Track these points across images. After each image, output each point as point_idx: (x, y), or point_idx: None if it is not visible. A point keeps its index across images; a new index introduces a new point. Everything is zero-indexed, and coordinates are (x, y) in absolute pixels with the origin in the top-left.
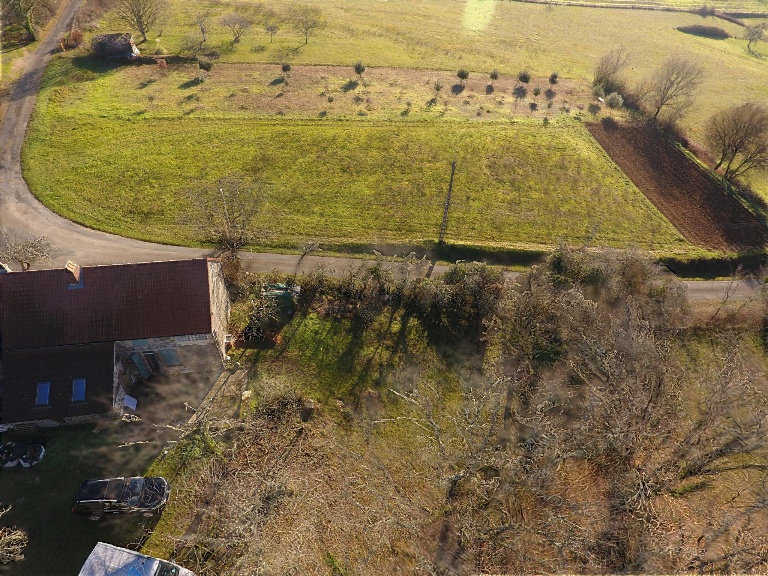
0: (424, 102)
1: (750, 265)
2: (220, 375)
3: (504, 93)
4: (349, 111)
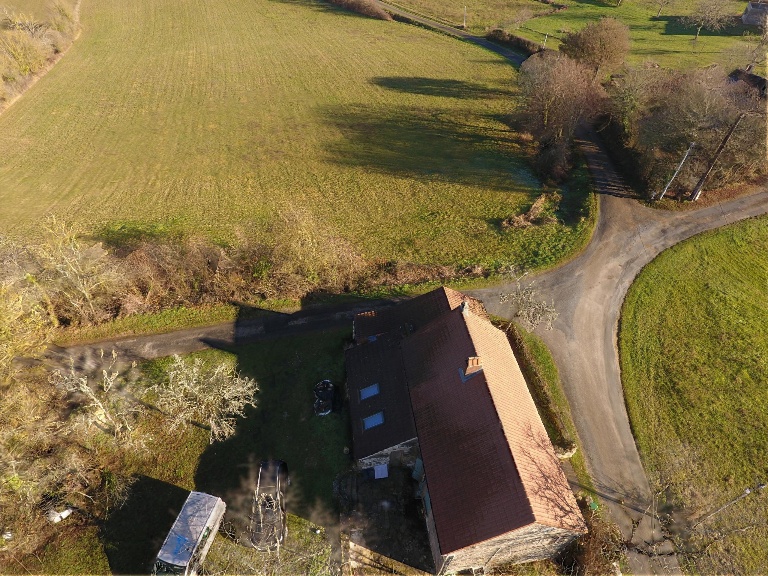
0: None
1: None
2: (427, 572)
3: None
4: None
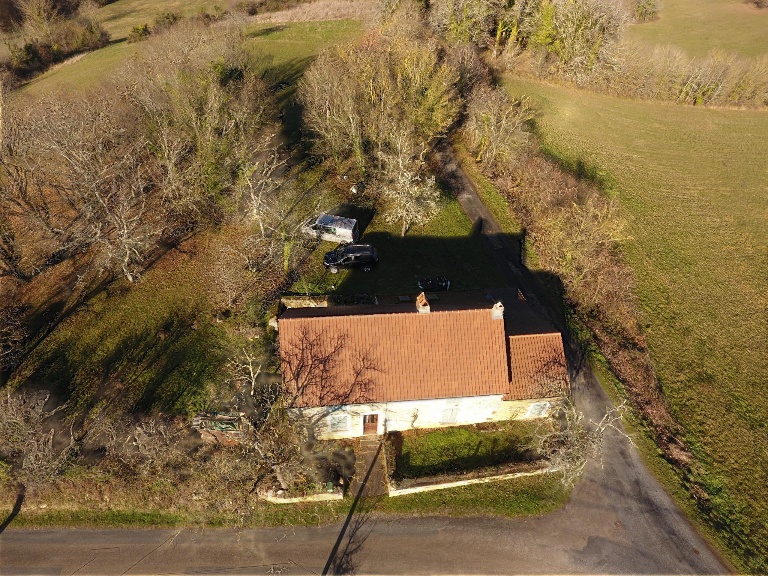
0: None
1: None
2: None
3: None
4: None
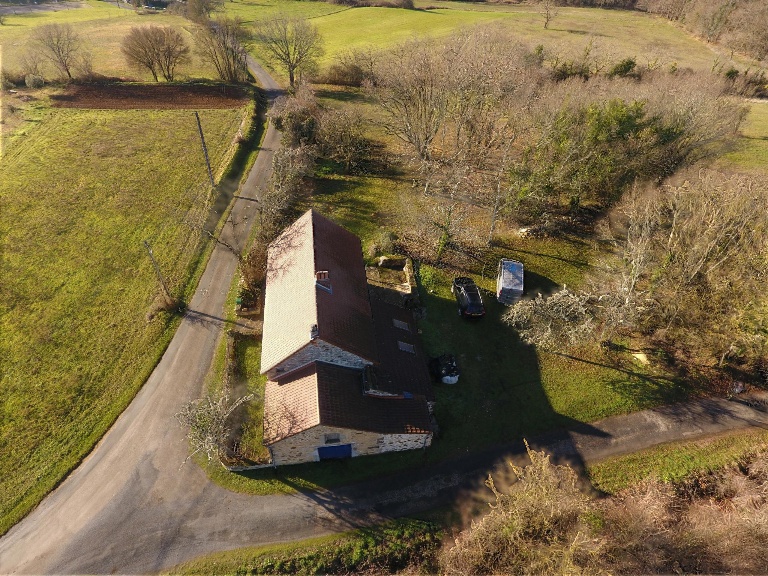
0: None
1: None
2: None
3: None
4: None
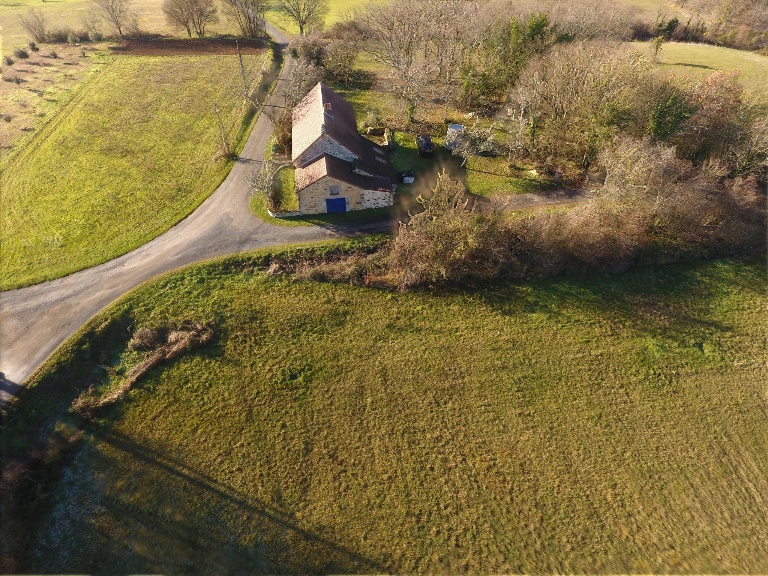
0: (33, 93)
1: (276, 51)
2: None
3: (38, 68)
4: (29, 120)
